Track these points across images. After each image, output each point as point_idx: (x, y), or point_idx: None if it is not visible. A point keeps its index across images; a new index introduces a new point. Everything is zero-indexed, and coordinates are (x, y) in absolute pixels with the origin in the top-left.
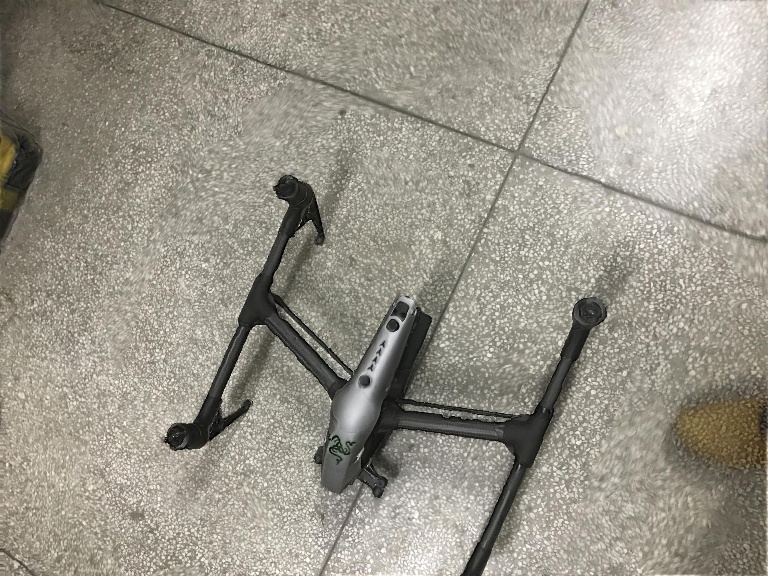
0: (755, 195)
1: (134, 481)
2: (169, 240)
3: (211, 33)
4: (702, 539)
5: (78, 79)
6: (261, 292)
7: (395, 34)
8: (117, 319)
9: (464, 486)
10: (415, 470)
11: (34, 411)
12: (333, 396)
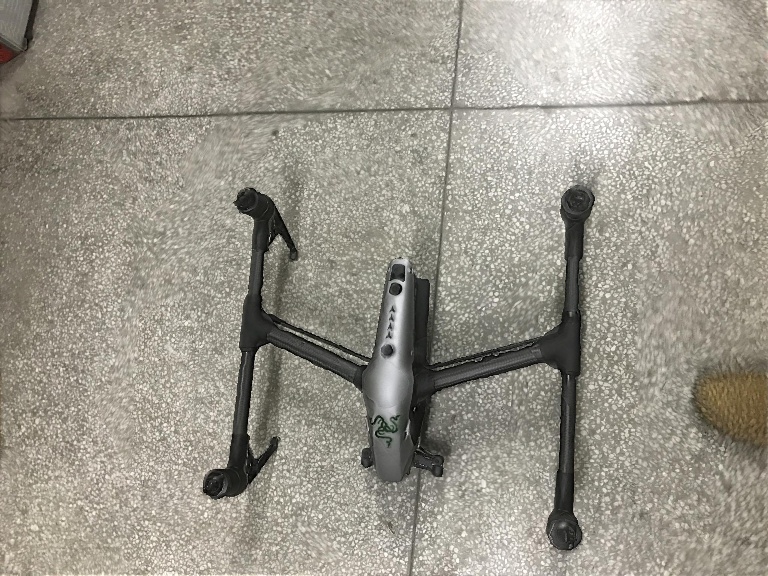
0: (679, 66)
1: (182, 569)
2: (143, 312)
3: (125, 107)
4: (767, 393)
5: (6, 196)
6: (254, 312)
7: (301, 47)
8: (113, 410)
9: (520, 435)
10: (466, 439)
11: (53, 539)
12: (360, 385)
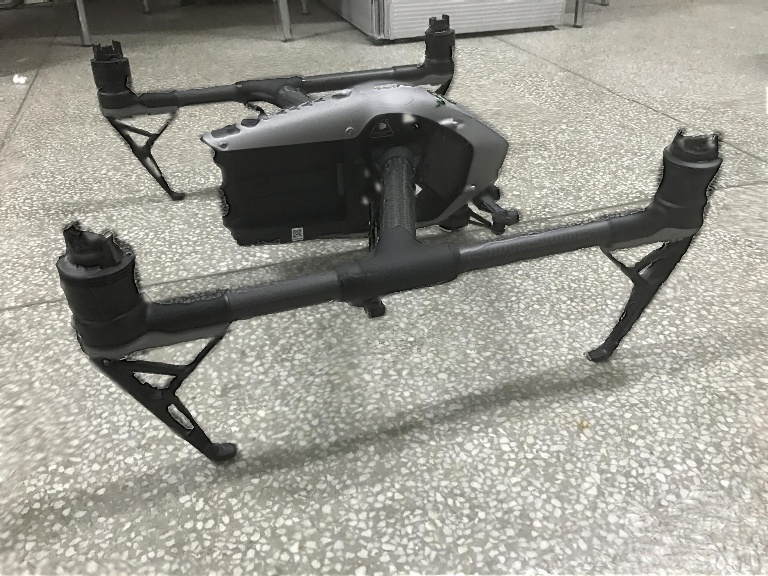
0: None
1: None
2: None
3: None
4: None
5: None
6: None
7: None
8: None
9: None
10: None
11: None
12: (408, 159)
